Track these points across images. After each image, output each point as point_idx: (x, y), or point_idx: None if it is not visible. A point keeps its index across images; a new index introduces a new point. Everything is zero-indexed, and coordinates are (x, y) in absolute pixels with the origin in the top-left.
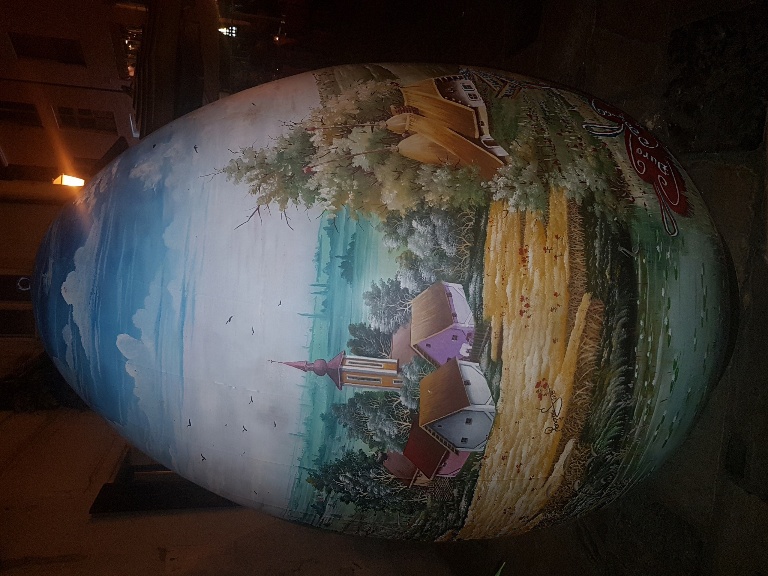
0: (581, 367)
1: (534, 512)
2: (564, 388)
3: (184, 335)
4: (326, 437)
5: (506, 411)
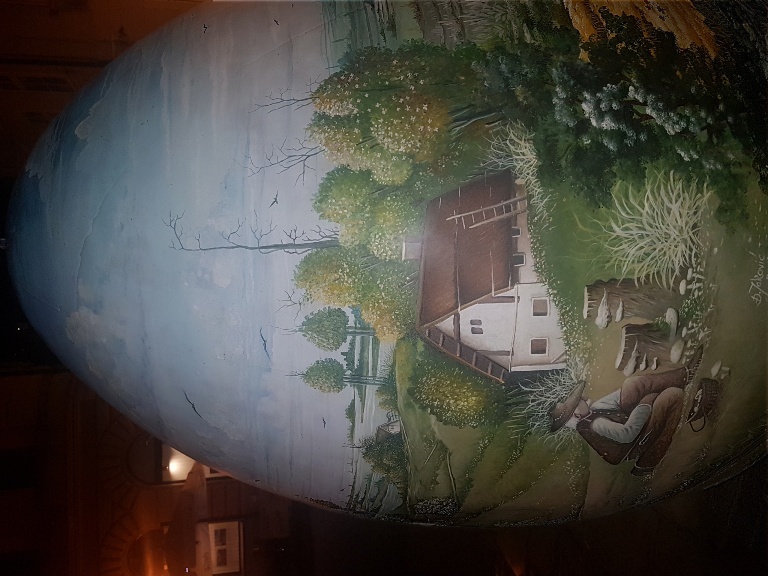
0: None
1: None
2: None
3: None
4: None
5: None
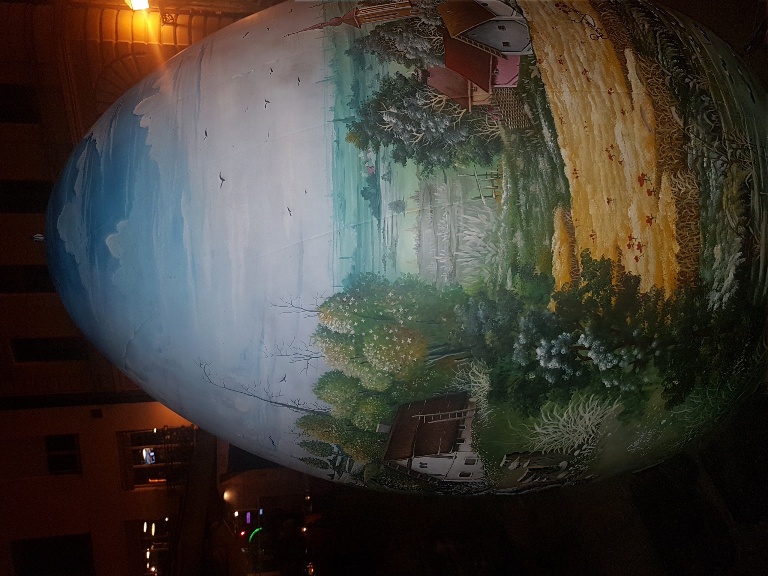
0: (593, 1)
1: (651, 167)
2: (586, 9)
3: (202, 64)
4: (356, 71)
5: (536, 20)
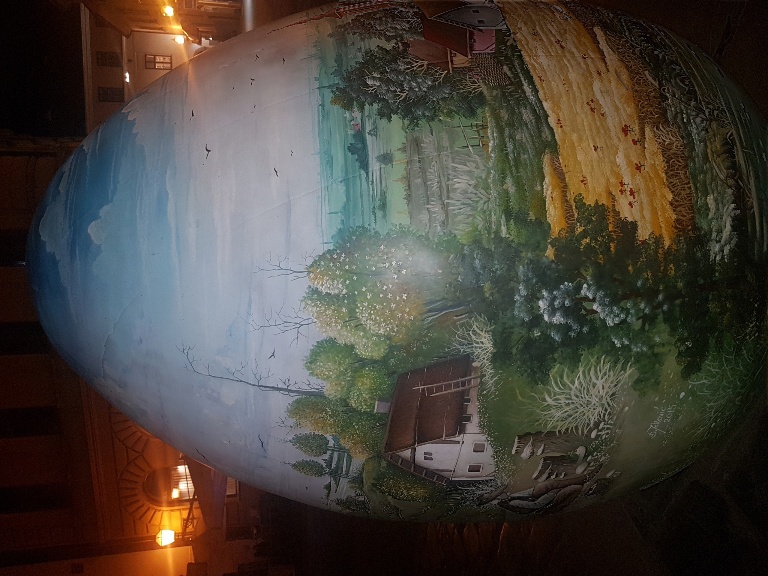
0: None
1: (633, 120)
2: (553, 2)
3: None
4: (339, 48)
5: None
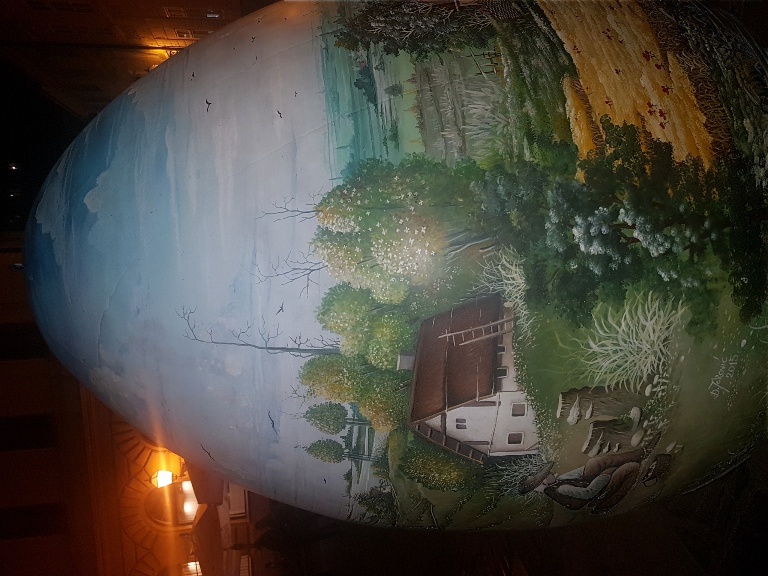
0: None
1: (654, 47)
2: None
3: None
4: (341, 2)
5: None
